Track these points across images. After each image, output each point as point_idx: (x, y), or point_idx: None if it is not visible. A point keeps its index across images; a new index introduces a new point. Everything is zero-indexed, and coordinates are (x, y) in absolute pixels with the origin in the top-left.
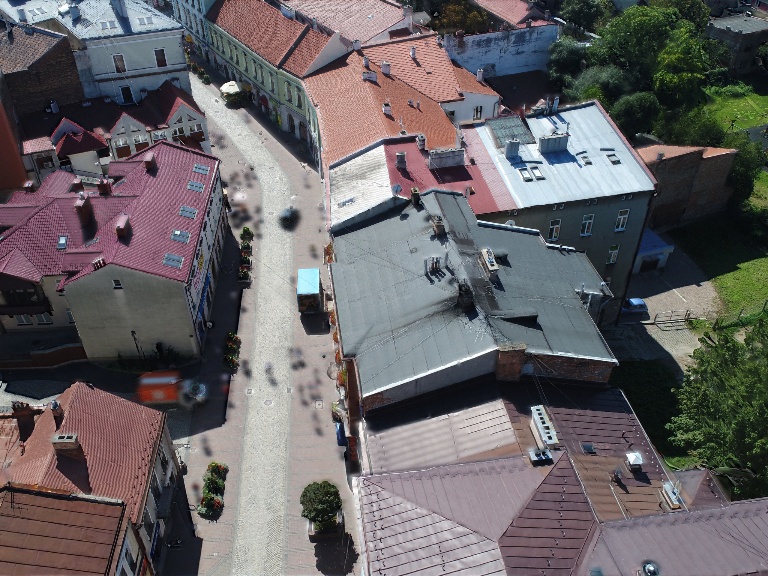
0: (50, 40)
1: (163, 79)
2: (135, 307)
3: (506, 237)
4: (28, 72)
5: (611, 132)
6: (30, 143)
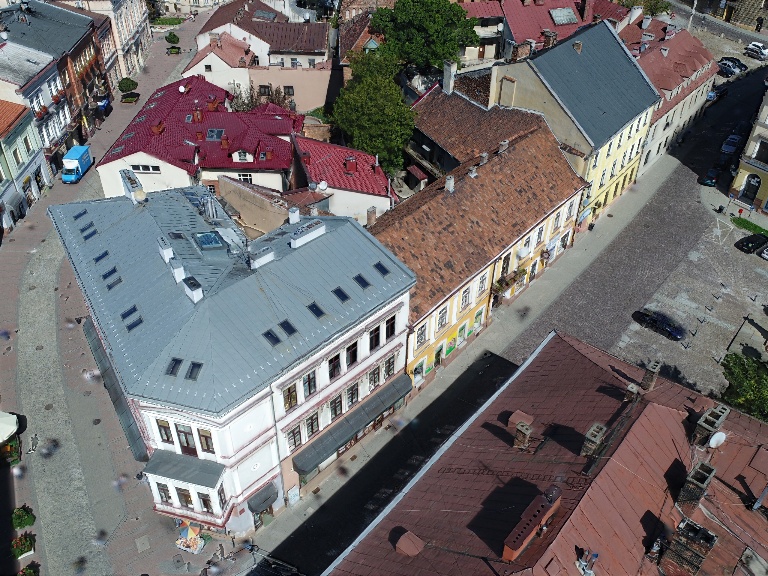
0: None
1: None
2: None
3: None
4: (283, 196)
5: None
6: None
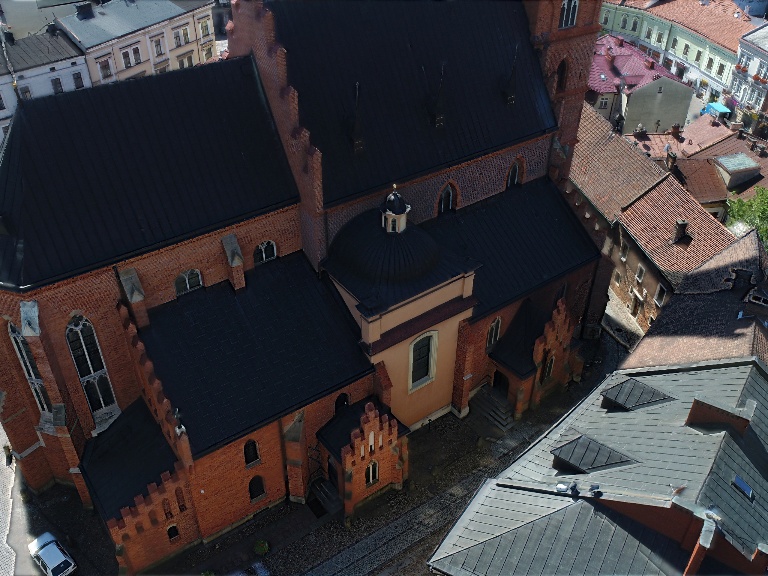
0: None
1: None
2: (663, 106)
3: None
4: None
5: None
6: None
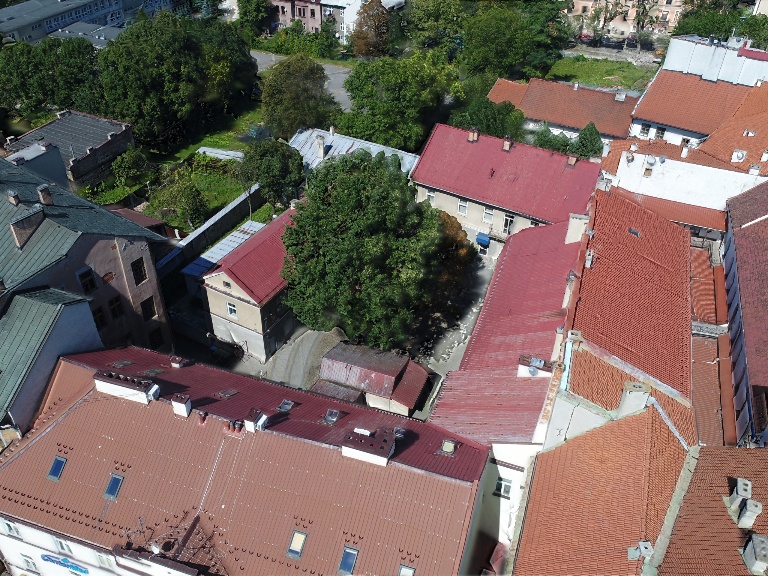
0: None
1: None
2: None
3: None
4: None
5: (688, 38)
6: None
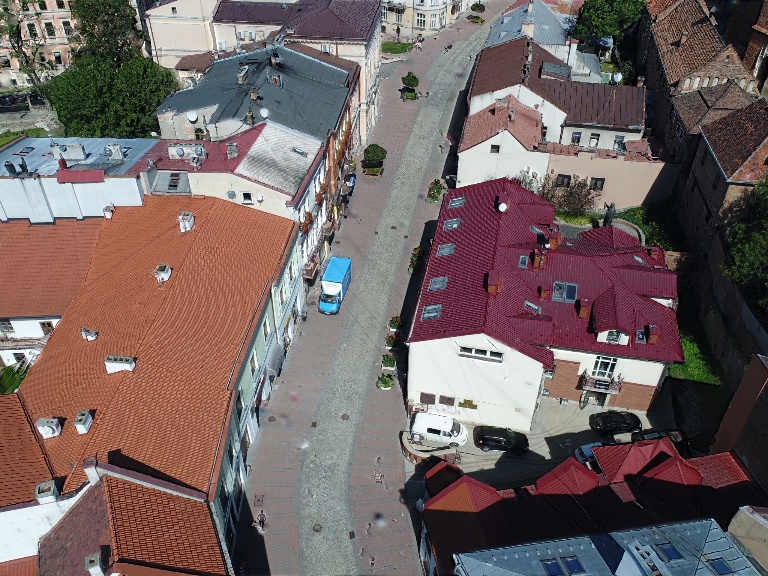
0: None
1: None
2: None
3: (205, 106)
4: None
5: None
6: (734, 473)
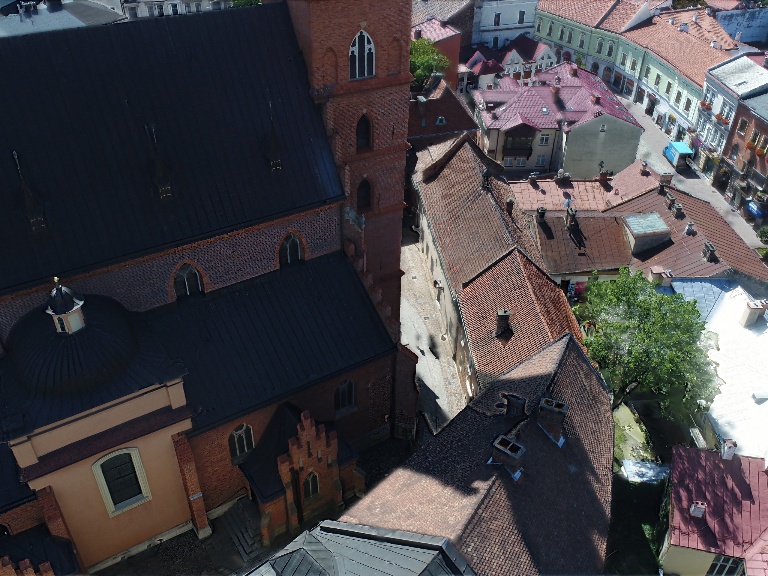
0: (460, 1)
1: (519, 33)
2: (606, 146)
3: None
4: (448, 21)
5: None
6: None
